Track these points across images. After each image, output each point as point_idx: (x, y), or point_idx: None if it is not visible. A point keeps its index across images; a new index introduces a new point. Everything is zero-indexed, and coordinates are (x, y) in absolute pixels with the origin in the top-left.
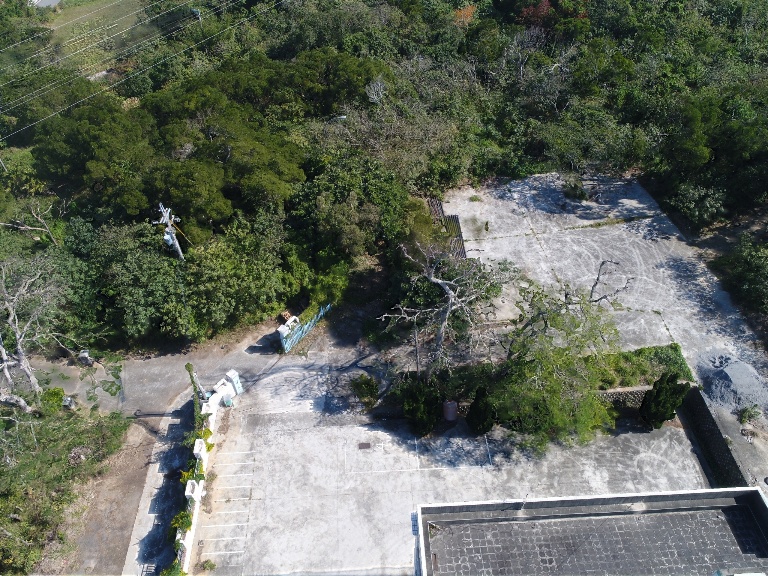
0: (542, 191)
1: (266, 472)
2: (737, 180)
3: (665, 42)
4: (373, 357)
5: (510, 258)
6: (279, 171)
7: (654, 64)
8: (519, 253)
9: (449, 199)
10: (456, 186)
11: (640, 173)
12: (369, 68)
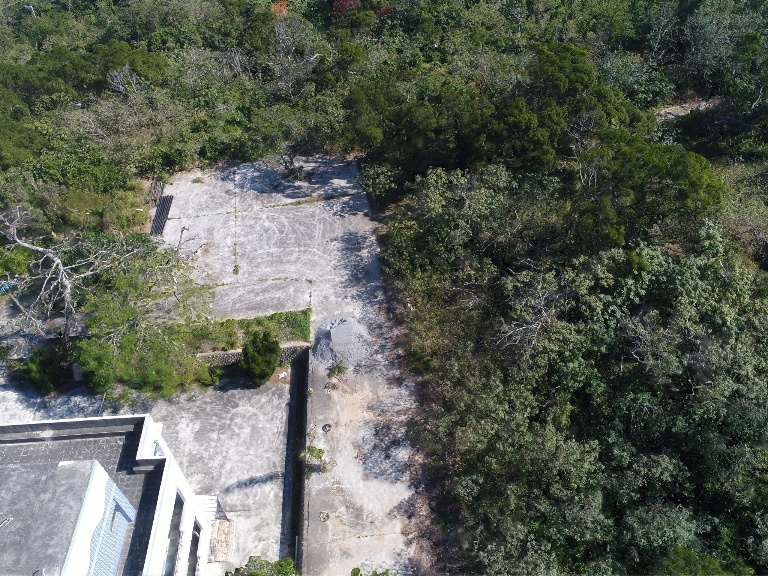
0: (264, 173)
1: None
2: (420, 159)
3: (442, 33)
4: None
5: (202, 234)
6: (1, 155)
7: (407, 53)
8: (212, 229)
9: (174, 181)
10: (186, 169)
11: (362, 155)
12: (133, 59)
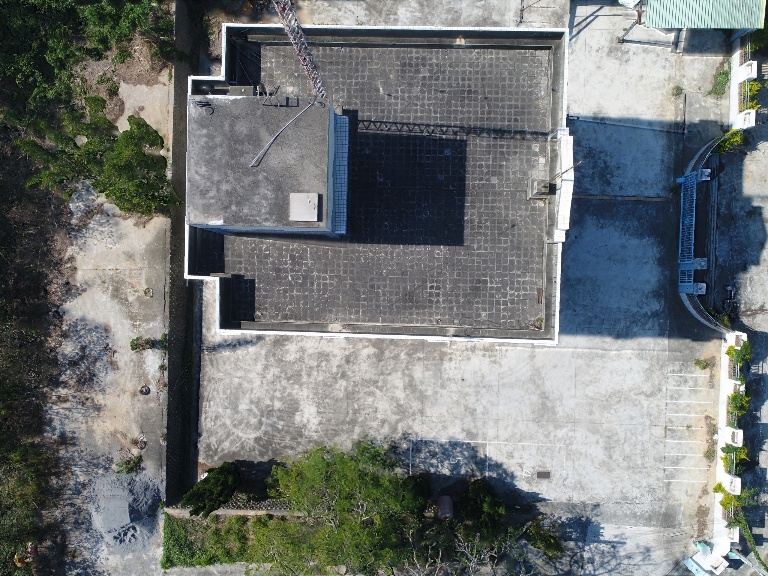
0: None
1: (651, 455)
2: None
3: None
4: None
5: None
6: None
7: None
8: None
9: None
10: None
11: None
12: None
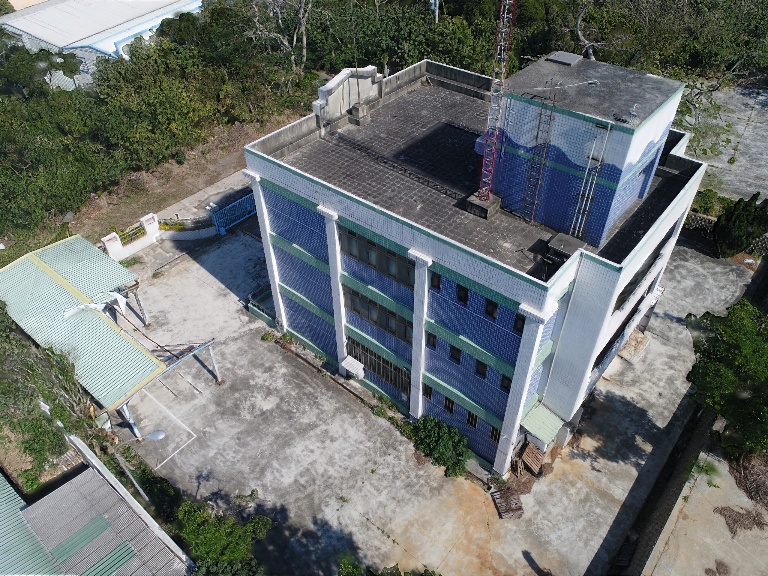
0: None
1: None
2: None
3: None
4: None
5: None
6: None
7: None
8: None
9: None
10: (705, 76)
11: None
12: None
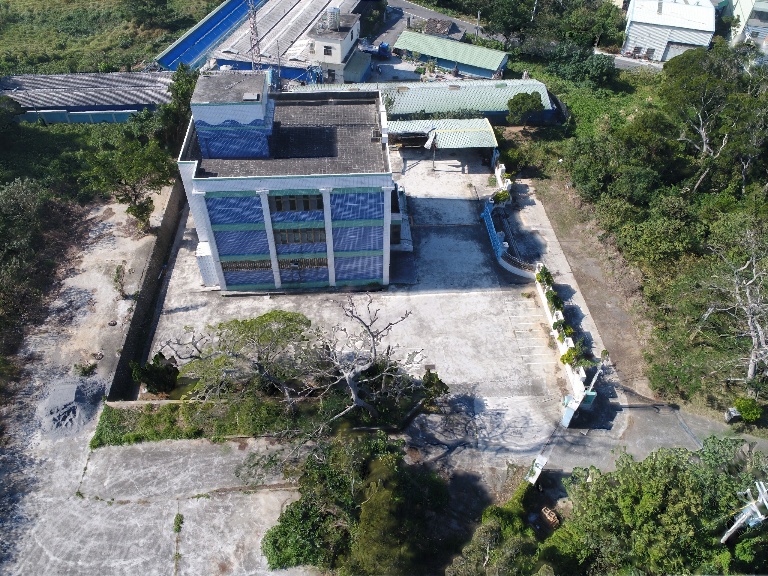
0: None
1: (509, 349)
2: None
3: None
4: (431, 456)
5: None
6: None
7: None
8: None
9: None
10: None
11: None
12: None
